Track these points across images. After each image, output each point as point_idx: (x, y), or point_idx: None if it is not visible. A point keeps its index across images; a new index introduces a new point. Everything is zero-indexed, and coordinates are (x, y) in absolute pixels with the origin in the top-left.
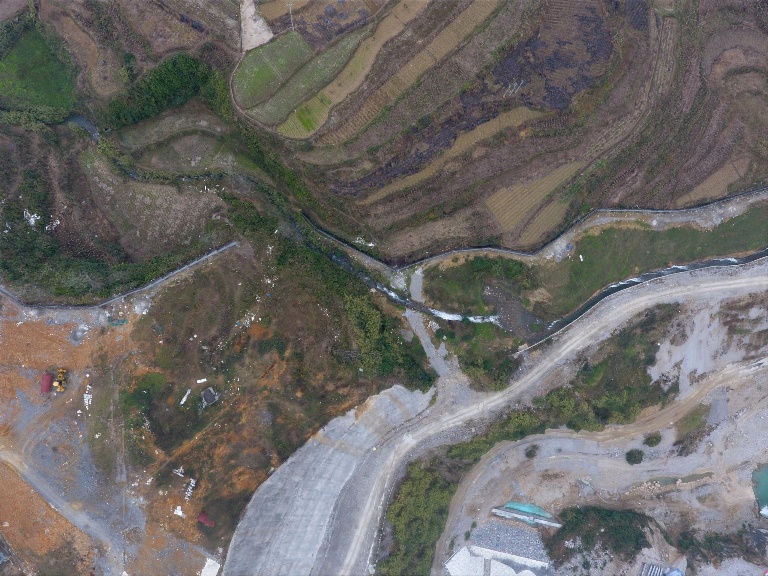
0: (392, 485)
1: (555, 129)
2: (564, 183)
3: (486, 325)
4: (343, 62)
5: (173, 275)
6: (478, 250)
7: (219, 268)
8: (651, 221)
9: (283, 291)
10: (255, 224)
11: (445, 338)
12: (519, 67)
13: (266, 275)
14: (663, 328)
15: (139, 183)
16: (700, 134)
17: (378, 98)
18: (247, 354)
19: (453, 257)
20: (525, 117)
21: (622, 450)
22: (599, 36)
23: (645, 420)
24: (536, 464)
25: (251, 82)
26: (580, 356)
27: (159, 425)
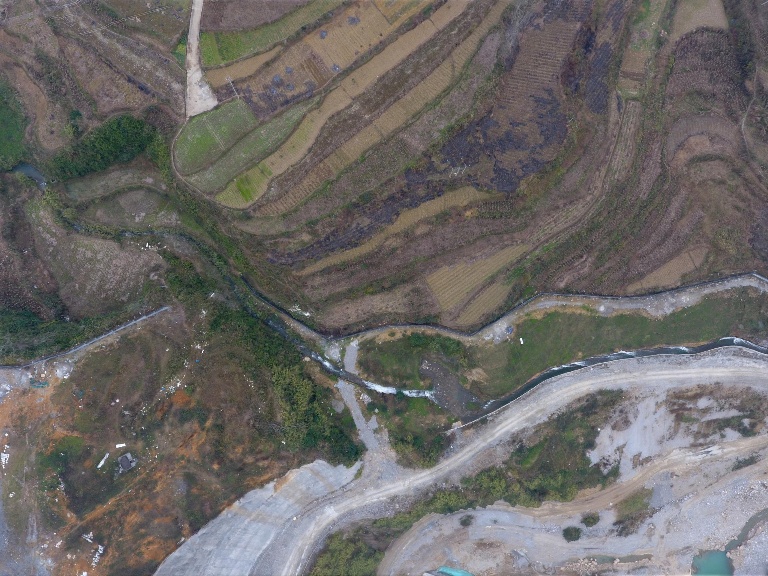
0: (309, 557)
1: (501, 211)
2: (508, 265)
3: (420, 400)
4: (286, 134)
5: (98, 340)
6: (416, 326)
7: (147, 333)
8: (599, 306)
9: (210, 360)
10: (192, 286)
11: (377, 411)
12: (468, 147)
13: (197, 340)
14: (605, 413)
15: (82, 236)
16: (656, 222)
17: (320, 171)
18: (168, 422)
19: (390, 332)
20: (471, 197)
21: (559, 526)
22: (554, 119)
23: (584, 499)
24: (471, 532)
25: (192, 149)
26: (514, 438)
27: (73, 488)
